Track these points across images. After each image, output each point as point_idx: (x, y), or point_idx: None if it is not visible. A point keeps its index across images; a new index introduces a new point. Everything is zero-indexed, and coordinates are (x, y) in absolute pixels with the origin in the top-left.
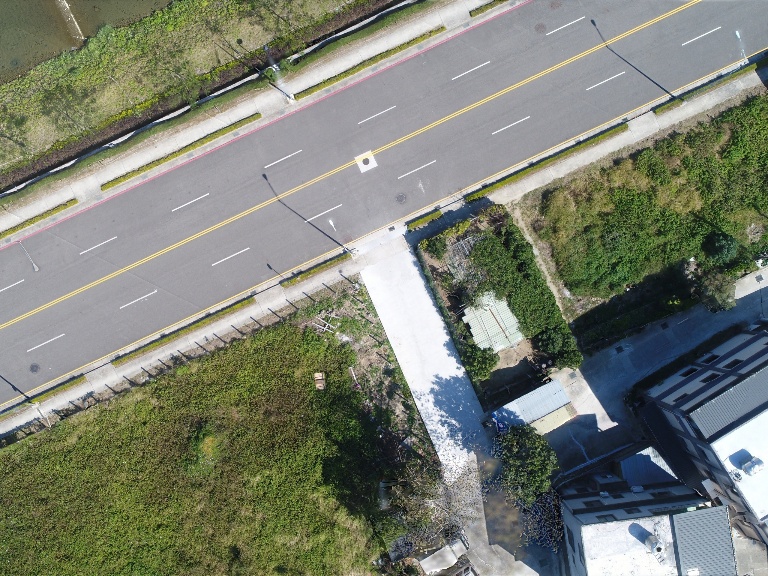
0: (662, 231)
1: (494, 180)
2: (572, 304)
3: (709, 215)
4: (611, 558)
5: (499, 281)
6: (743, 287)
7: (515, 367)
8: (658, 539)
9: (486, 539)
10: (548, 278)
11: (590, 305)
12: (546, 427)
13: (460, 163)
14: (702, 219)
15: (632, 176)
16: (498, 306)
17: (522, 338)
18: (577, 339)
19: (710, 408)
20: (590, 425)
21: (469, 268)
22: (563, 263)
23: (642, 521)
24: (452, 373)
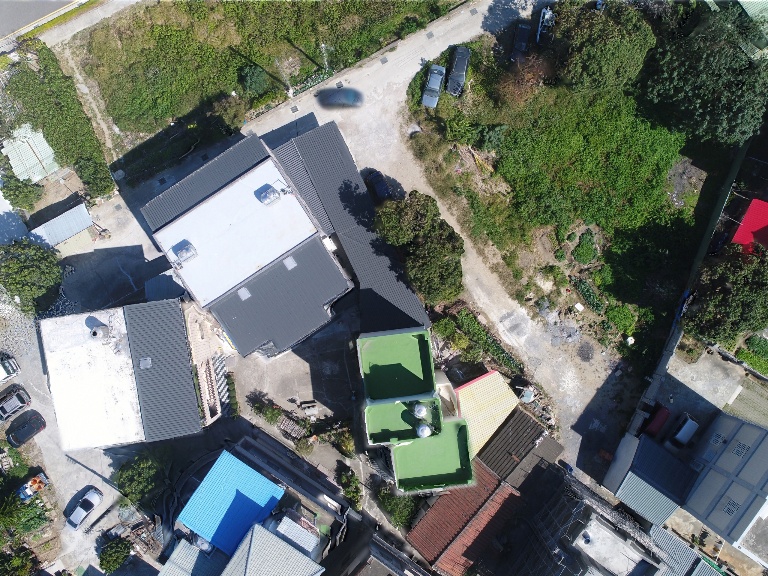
0: (200, 65)
1: (46, 22)
2: (121, 140)
3: (245, 49)
4: (69, 350)
5: (34, 113)
6: (279, 118)
7: (64, 201)
8: (112, 331)
9: (40, 369)
10: (98, 115)
11: (138, 140)
12: (68, 249)
13: (12, 5)
14: (237, 52)
15: (170, 12)
16: (35, 138)
17: (58, 168)
18: (125, 173)
19: (158, 203)
20: (137, 256)
21: (5, 101)
22: (108, 99)
23: (98, 314)
24: (5, 209)
